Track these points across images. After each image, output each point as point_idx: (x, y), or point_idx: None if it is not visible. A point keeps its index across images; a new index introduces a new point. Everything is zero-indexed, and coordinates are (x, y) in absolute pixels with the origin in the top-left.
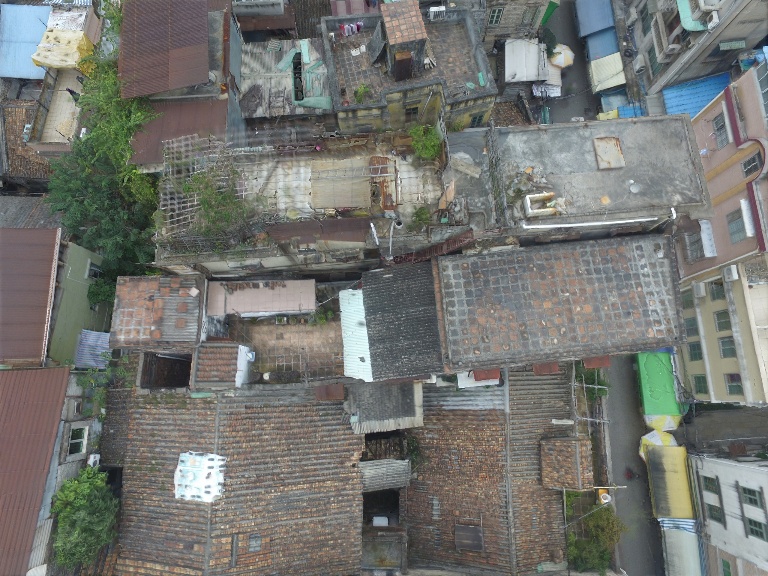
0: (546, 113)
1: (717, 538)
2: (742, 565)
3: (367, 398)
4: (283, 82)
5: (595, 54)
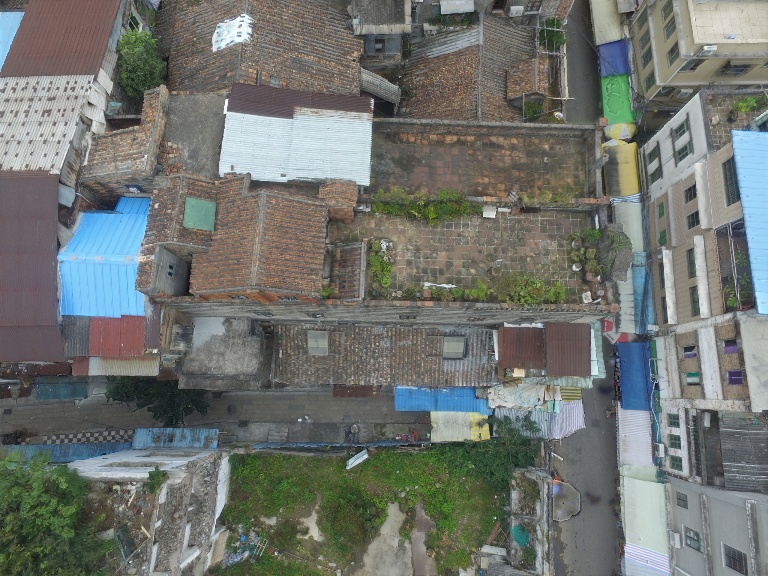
0: None
1: (655, 191)
2: (671, 190)
3: (366, 5)
4: None
5: None
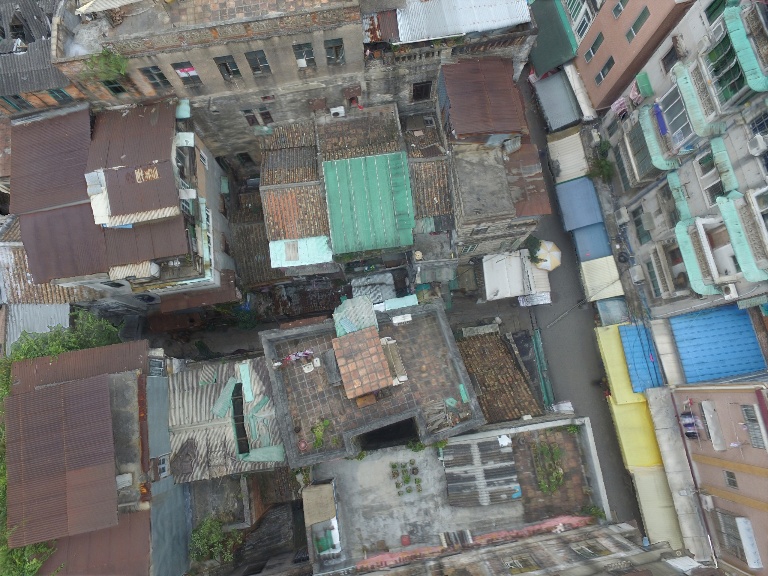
0: (537, 339)
1: None
2: None
3: None
4: (222, 432)
5: (584, 251)
